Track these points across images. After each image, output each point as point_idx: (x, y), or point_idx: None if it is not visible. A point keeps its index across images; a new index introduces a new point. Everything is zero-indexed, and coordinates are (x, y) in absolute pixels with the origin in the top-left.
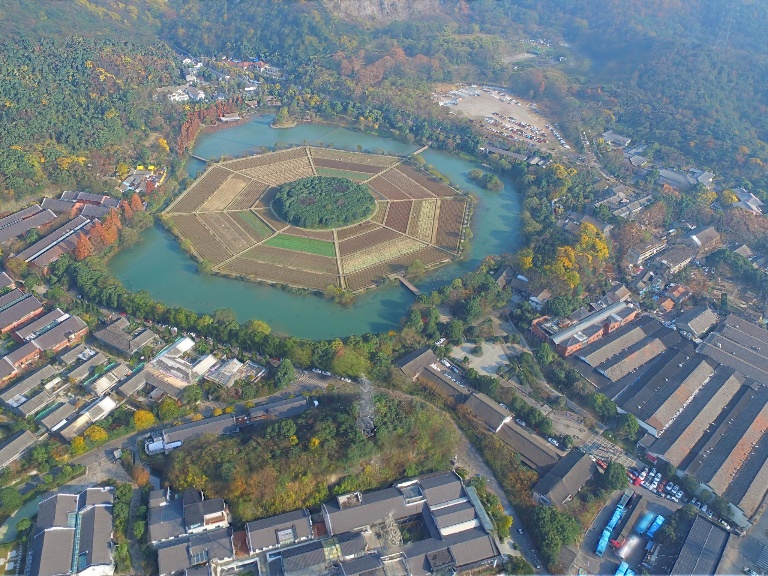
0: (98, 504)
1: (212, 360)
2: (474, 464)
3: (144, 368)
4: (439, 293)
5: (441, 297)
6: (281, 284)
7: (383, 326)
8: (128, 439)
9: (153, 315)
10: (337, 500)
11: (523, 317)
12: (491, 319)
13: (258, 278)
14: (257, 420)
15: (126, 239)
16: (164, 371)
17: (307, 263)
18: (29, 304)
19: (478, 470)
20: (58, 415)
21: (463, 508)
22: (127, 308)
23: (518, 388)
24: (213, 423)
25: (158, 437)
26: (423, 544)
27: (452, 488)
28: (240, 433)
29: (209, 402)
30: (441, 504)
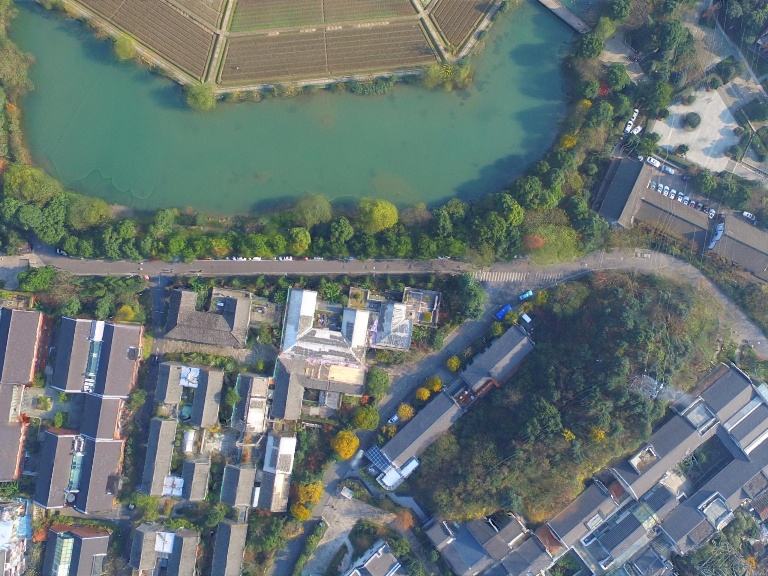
0: (388, 575)
1: (363, 315)
2: (738, 327)
3: (288, 372)
4: (611, 19)
5: (615, 26)
6: (344, 84)
7: (537, 114)
8: (337, 463)
9: (211, 254)
10: (631, 466)
11: (747, 23)
12: (690, 33)
13: (296, 81)
14: (483, 392)
15: (14, 83)
16: (312, 359)
17: (351, 4)
18: (22, 325)
19: (745, 334)
20: (244, 487)
21: (762, 417)
22: (164, 259)
23: (757, 169)
24: (437, 422)
25: (387, 468)
26: (732, 473)
27: (743, 396)
28: (470, 413)
29: (392, 370)
30: (735, 418)
